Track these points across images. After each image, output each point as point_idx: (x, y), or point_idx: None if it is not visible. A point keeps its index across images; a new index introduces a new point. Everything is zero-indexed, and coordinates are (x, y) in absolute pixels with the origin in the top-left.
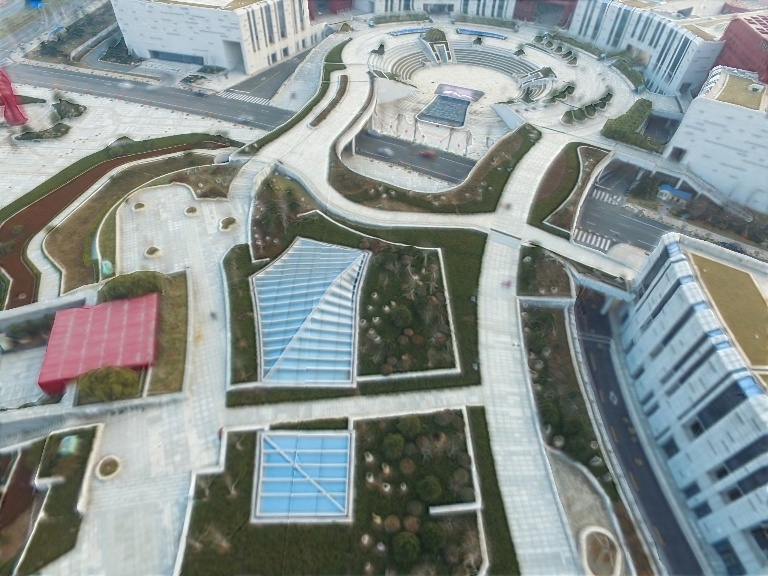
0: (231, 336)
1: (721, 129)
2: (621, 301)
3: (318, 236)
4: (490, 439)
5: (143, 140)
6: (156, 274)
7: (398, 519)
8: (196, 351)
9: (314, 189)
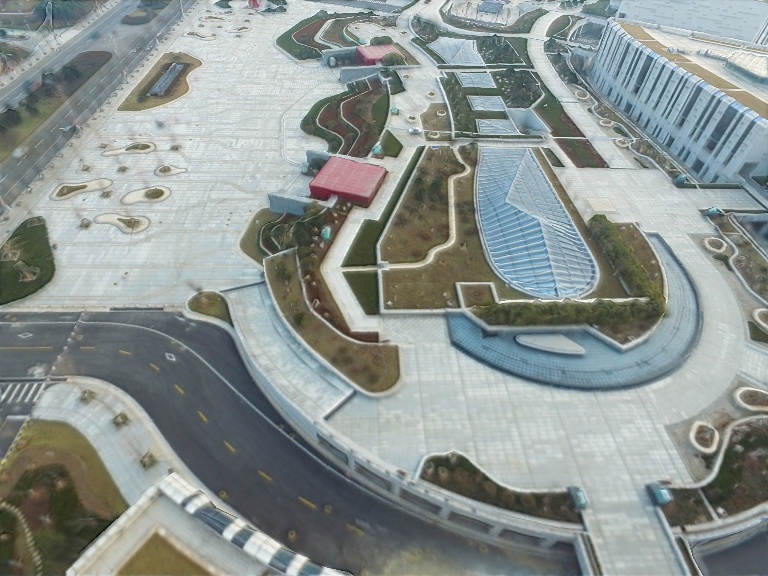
0: (430, 55)
1: None
2: (591, 60)
3: (449, 36)
4: (541, 78)
5: (329, 14)
6: None
7: (513, 86)
8: None
9: None
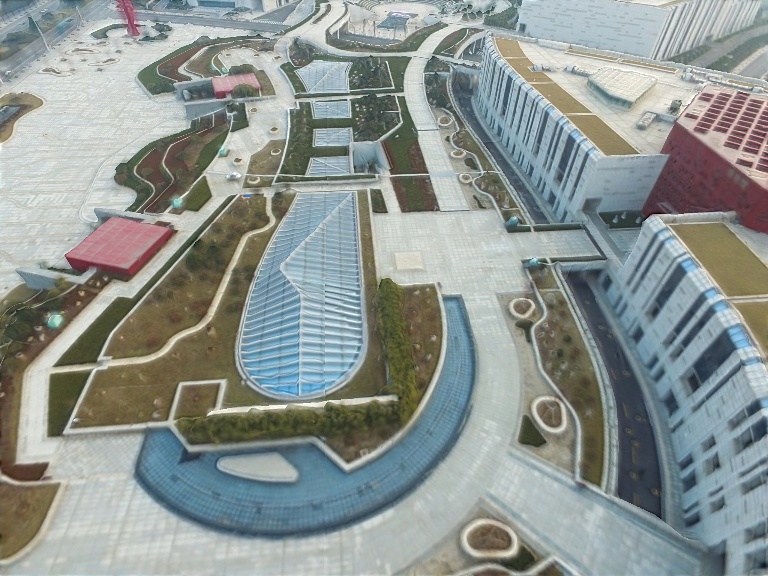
0: (292, 83)
1: (540, 8)
2: (476, 78)
3: (325, 59)
4: (406, 103)
5: (214, 39)
6: (252, 66)
7: None
8: None
9: (320, 45)
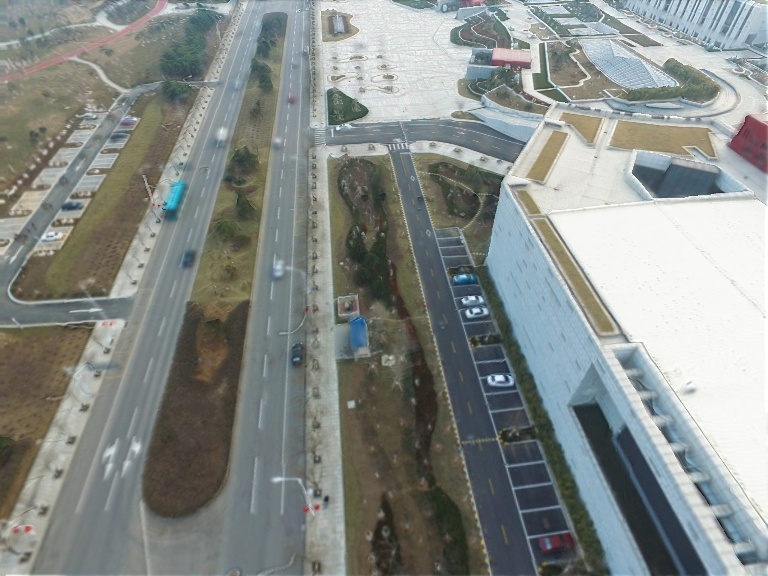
0: None
1: None
2: None
3: None
4: None
5: None
6: None
7: None
8: None
9: None
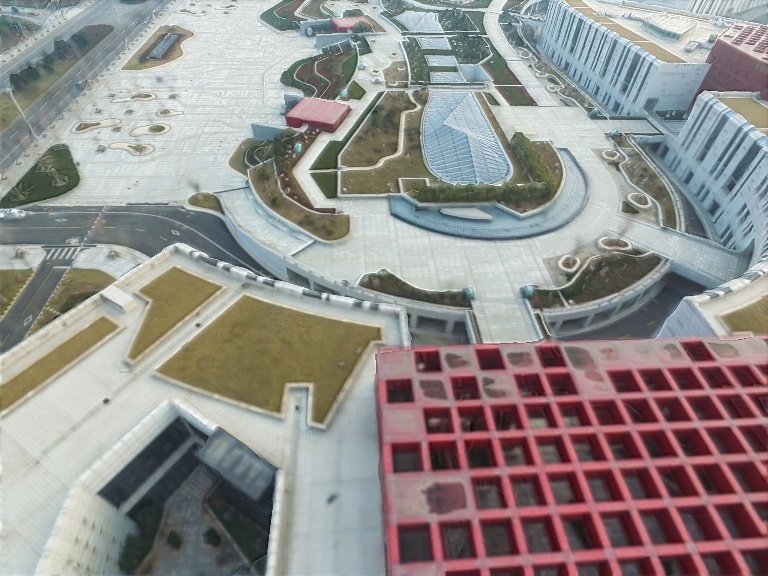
0: (396, 25)
1: None
2: (540, 30)
3: (415, 10)
4: None
5: None
6: (361, 11)
7: None
8: (384, 28)
9: (406, 0)
